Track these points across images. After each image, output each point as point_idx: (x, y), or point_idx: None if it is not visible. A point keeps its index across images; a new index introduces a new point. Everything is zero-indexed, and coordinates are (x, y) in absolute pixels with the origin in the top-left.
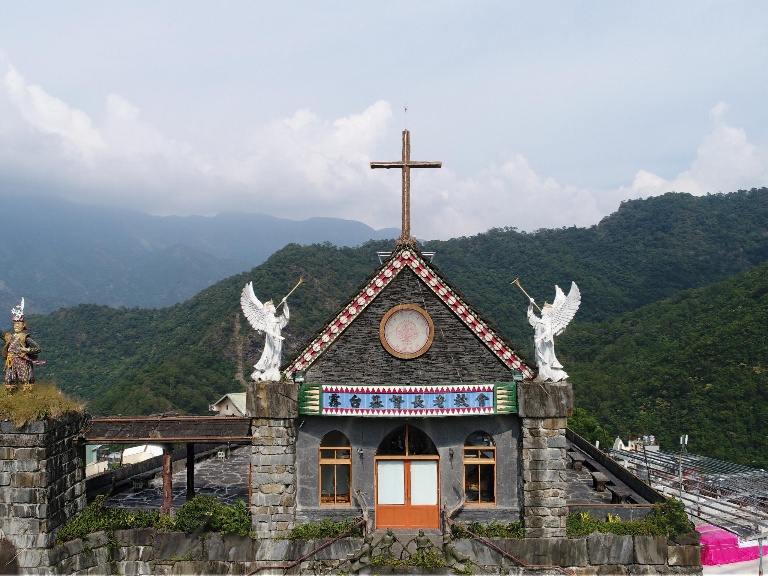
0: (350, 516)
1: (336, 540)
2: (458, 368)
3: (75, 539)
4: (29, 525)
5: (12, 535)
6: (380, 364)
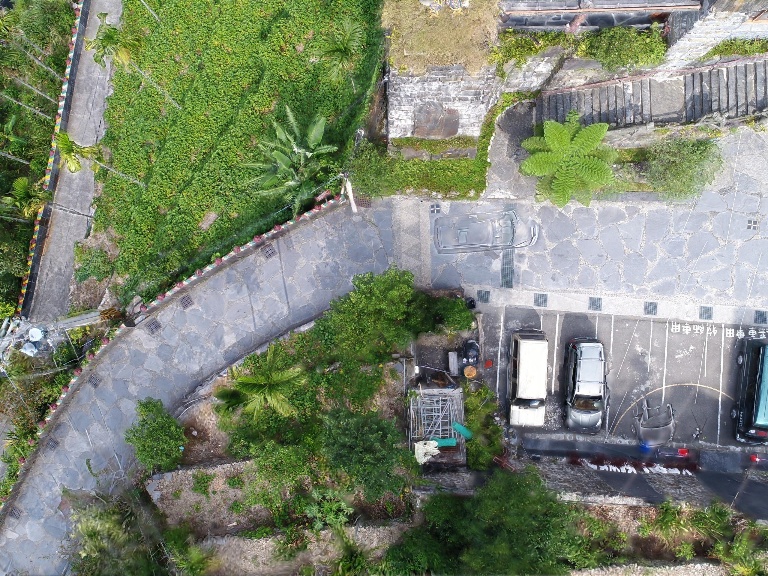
0: (764, 34)
1: (742, 58)
2: None
3: (496, 77)
4: (472, 103)
5: (455, 106)
6: None
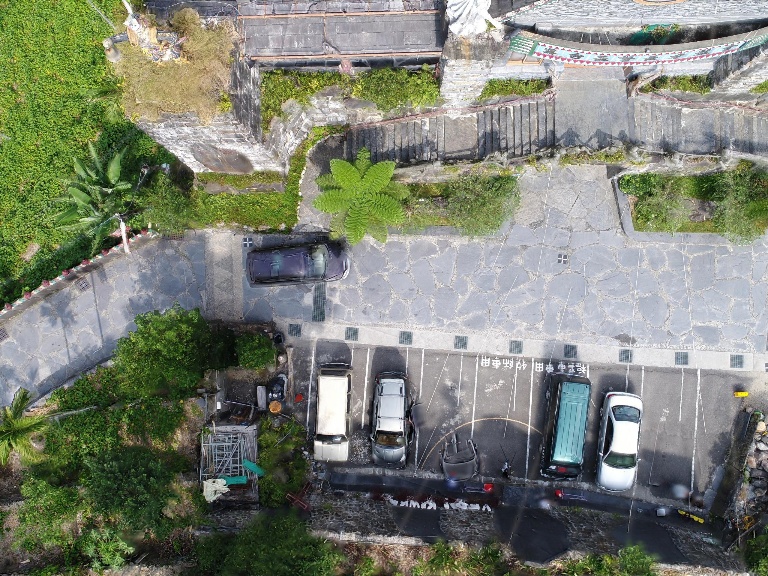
0: (537, 75)
1: (521, 98)
2: (719, 6)
3: (274, 117)
4: (242, 144)
5: (229, 147)
6: (618, 6)
